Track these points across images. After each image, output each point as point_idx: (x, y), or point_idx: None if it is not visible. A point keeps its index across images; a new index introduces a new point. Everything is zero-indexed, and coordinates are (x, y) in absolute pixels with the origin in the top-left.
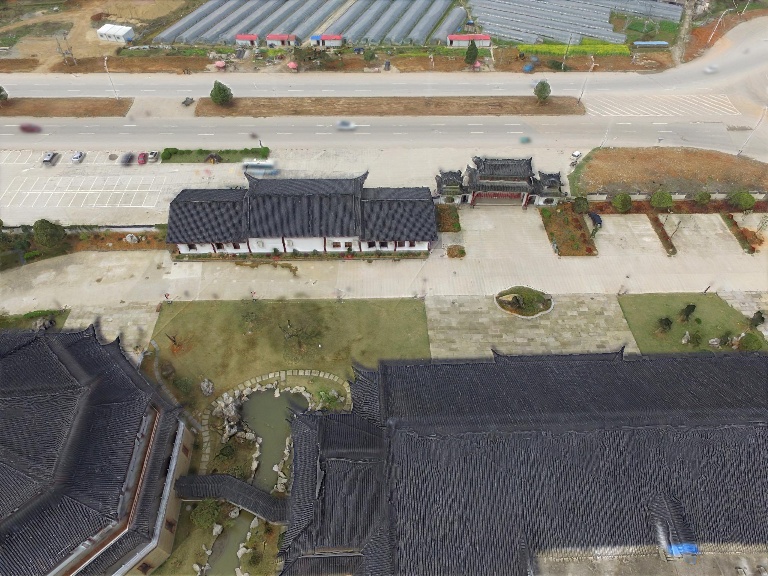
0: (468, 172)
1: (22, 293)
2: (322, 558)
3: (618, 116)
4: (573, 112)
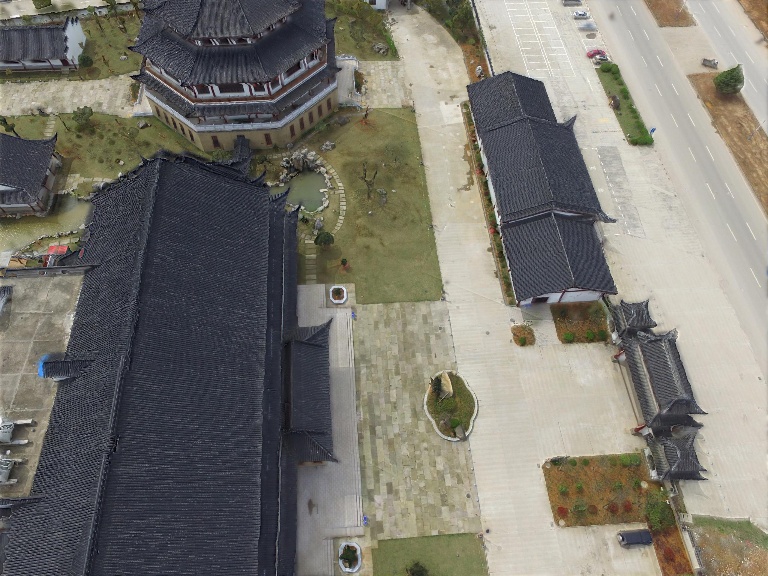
0: None
1: (413, 32)
2: None
3: None
4: None
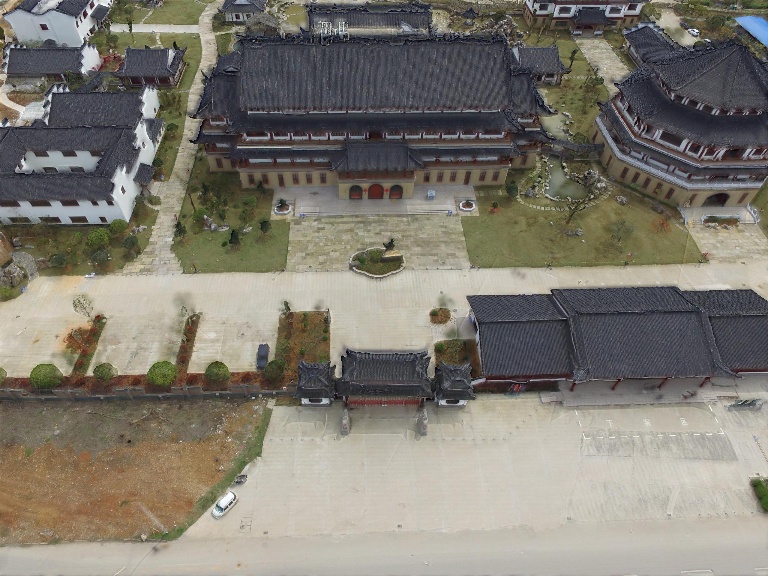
0: None
1: None
2: None
3: None
4: None
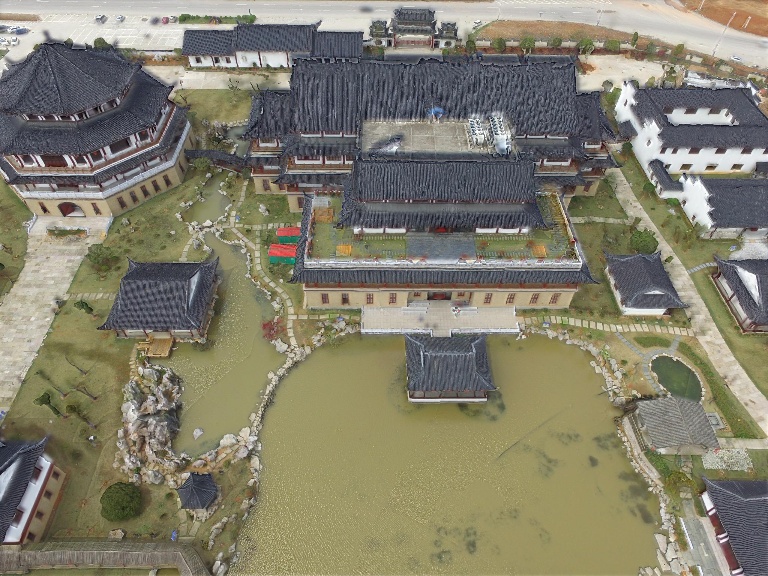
0: (392, 23)
1: None
2: (264, 158)
3: (518, 3)
4: (484, 0)
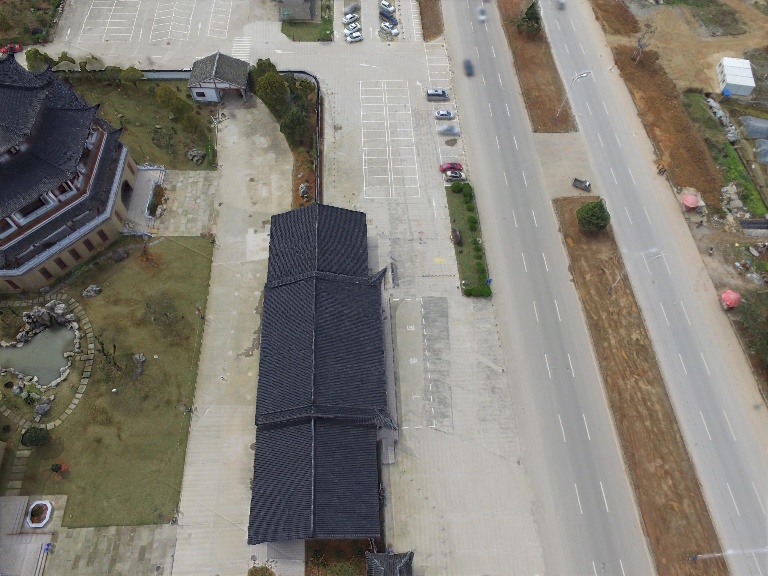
0: None
1: (242, 133)
2: None
3: None
4: None
